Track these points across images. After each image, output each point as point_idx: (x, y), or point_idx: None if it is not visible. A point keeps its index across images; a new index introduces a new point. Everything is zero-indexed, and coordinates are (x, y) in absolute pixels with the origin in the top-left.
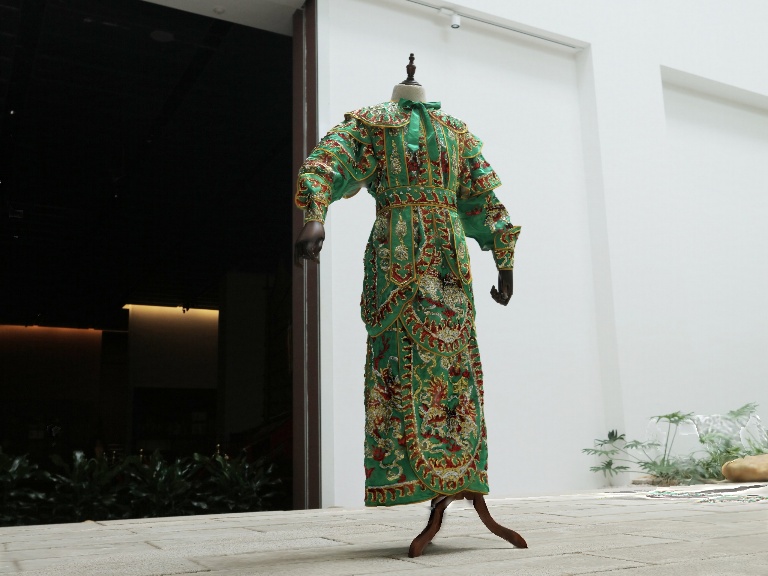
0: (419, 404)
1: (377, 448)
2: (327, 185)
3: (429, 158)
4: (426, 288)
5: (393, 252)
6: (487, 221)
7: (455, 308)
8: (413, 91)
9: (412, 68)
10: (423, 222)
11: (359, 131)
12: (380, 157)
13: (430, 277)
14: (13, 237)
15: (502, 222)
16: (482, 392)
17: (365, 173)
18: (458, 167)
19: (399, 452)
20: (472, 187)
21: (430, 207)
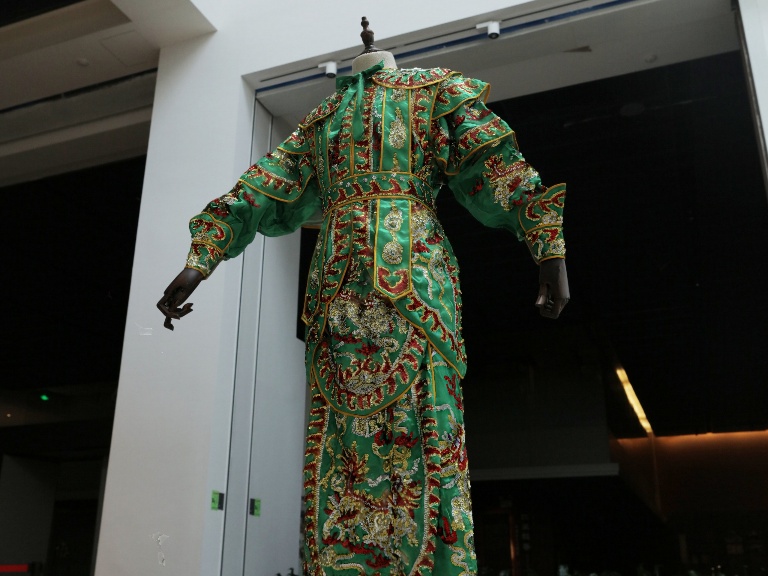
0: (330, 493)
1: (306, 561)
2: (215, 221)
3: (353, 140)
4: (335, 320)
5: (309, 280)
6: (499, 195)
7: (380, 340)
8: (361, 62)
9: (364, 35)
10: (334, 229)
11: (298, 141)
12: (313, 163)
13: (343, 302)
14: (161, 353)
15: (521, 188)
16: (433, 467)
17: (301, 189)
18: (413, 135)
19: (310, 567)
20: (456, 154)
21: (350, 205)
